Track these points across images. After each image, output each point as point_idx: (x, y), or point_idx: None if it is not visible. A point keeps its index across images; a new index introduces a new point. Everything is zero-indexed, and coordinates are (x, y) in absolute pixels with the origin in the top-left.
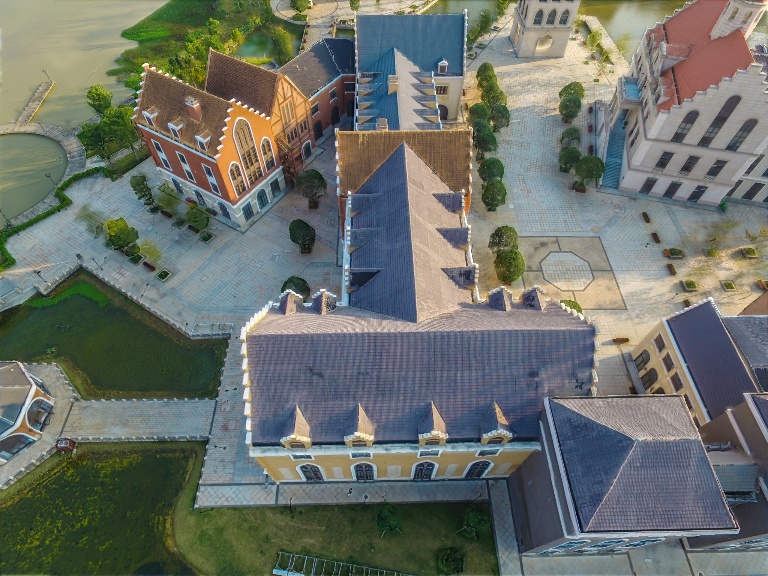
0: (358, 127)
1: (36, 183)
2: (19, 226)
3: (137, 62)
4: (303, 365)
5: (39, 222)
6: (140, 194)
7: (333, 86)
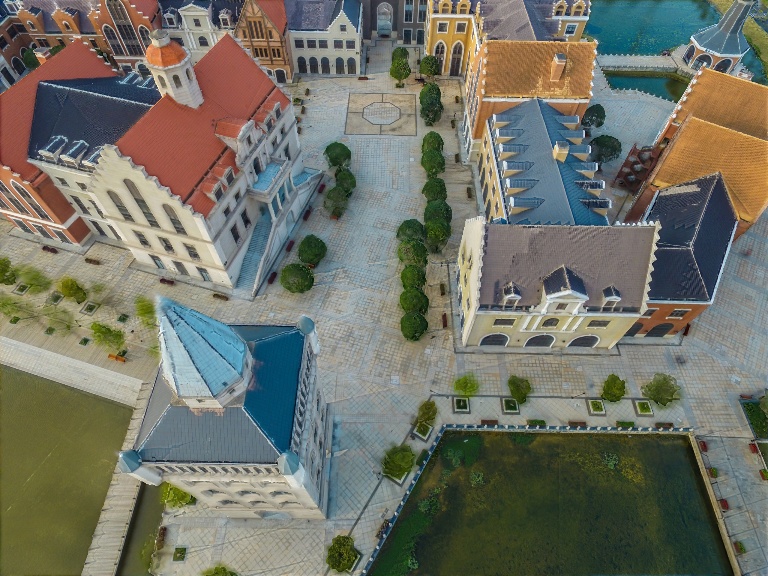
0: None
1: None
2: None
3: None
4: None
5: None
6: None
7: None
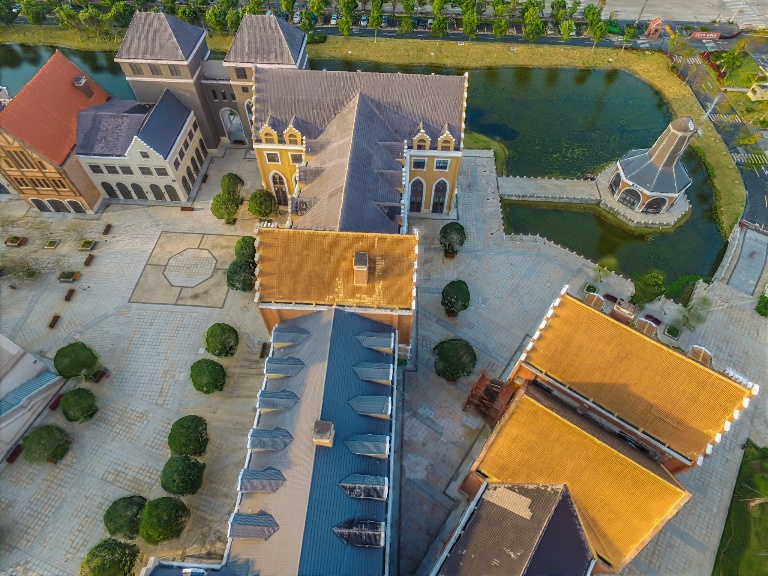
0: (389, 367)
1: None
2: None
3: None
4: None
5: None
6: None
7: None
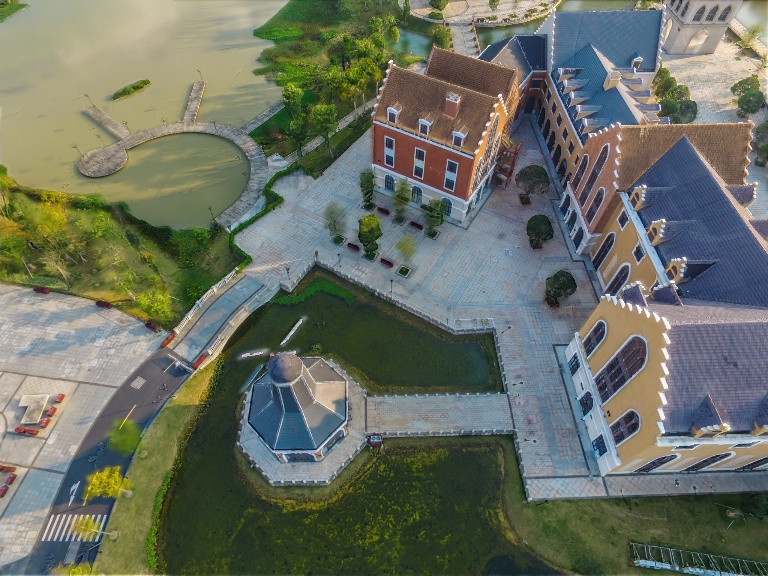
0: (587, 122)
1: (224, 182)
2: (243, 224)
3: (281, 61)
4: (719, 354)
5: (258, 220)
6: (366, 191)
7: (526, 83)
